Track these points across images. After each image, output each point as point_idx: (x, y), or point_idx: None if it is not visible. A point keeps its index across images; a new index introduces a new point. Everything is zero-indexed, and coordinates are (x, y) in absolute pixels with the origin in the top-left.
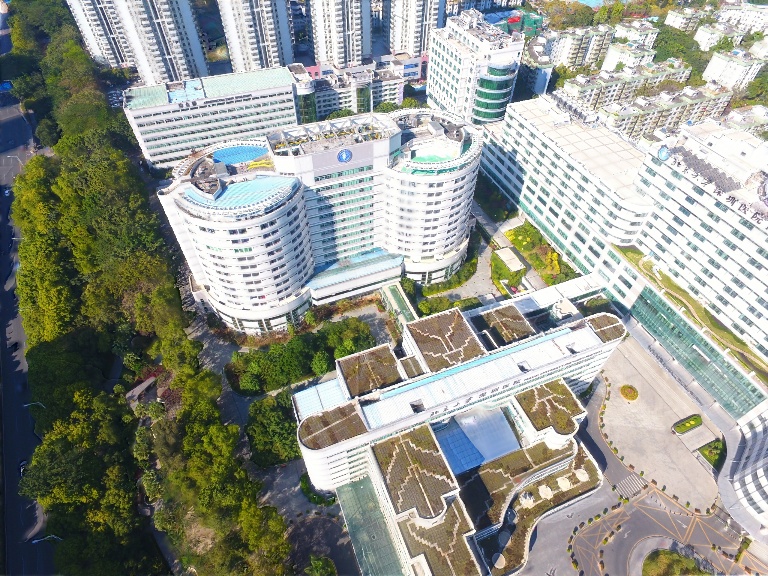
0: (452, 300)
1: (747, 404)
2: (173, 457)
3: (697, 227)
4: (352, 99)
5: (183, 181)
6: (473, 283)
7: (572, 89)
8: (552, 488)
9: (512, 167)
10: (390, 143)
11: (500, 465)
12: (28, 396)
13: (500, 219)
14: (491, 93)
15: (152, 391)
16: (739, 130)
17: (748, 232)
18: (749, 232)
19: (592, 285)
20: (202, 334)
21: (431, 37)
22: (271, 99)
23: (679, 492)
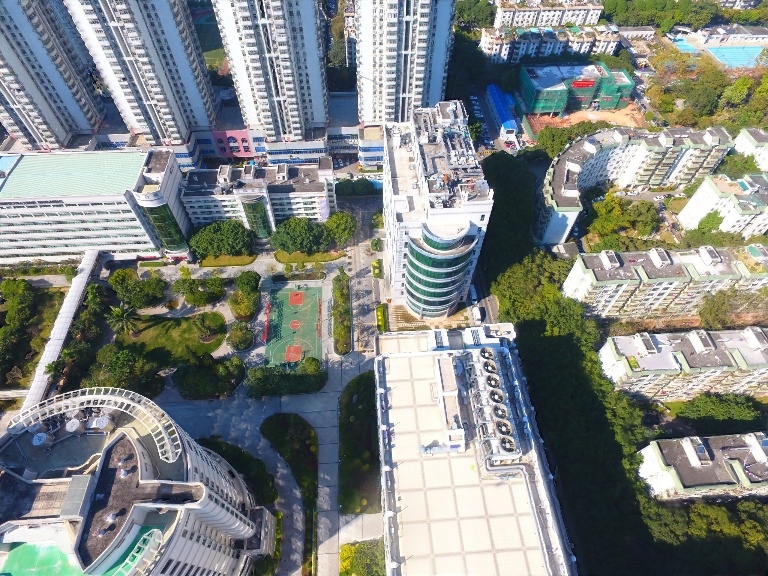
0: None
1: None
2: None
3: None
4: None
5: None
6: None
7: (584, 274)
8: None
9: None
10: None
11: None
12: None
13: (349, 512)
14: (423, 268)
15: None
16: None
17: None
18: None
19: None
20: None
21: None
22: (96, 208)
23: None
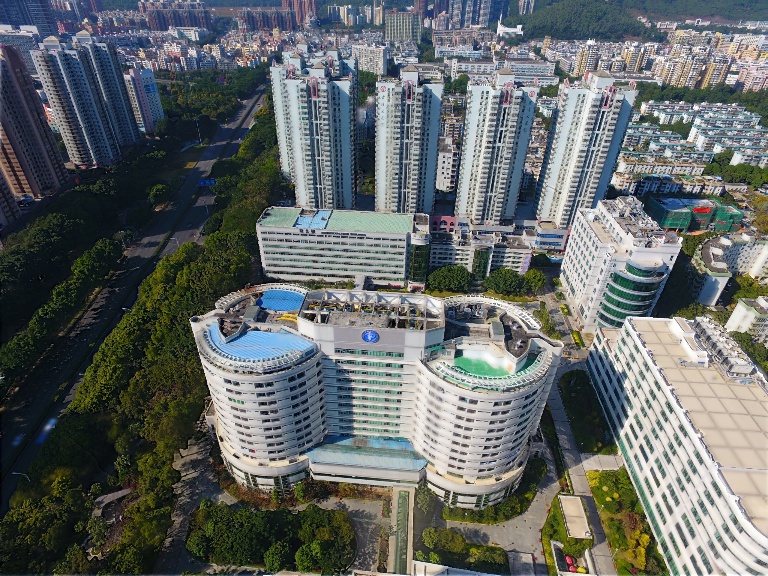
0: (476, 540)
1: None
2: None
3: None
4: (469, 258)
5: (216, 314)
6: (514, 527)
7: (747, 312)
8: None
9: (619, 391)
10: (426, 336)
11: None
12: None
13: (588, 450)
14: (625, 292)
15: None
16: None
17: None
18: None
19: None
20: (202, 459)
21: (576, 215)
22: (384, 242)
23: None
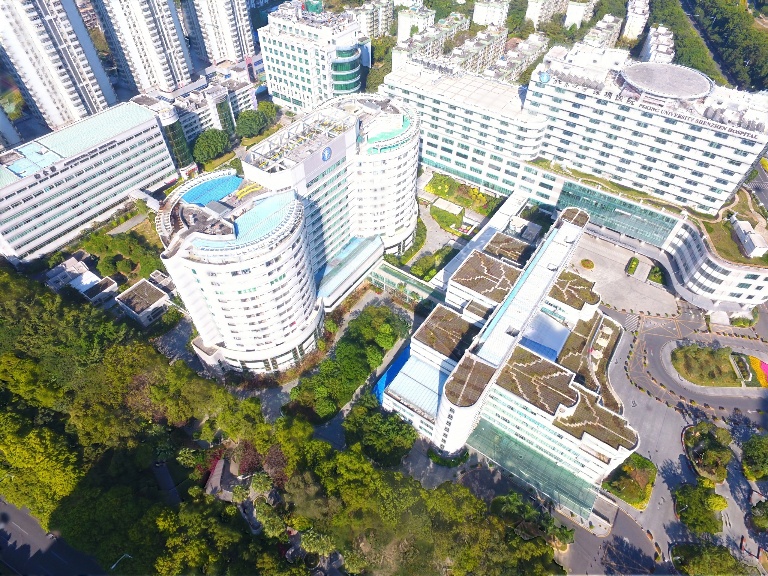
0: None
1: (666, 232)
2: (324, 504)
3: (587, 124)
4: (213, 117)
5: (183, 235)
6: (431, 238)
7: (401, 55)
8: (598, 349)
9: None
10: (355, 130)
11: (568, 350)
12: (76, 570)
13: None
14: (347, 74)
15: (225, 475)
16: (583, 46)
17: (627, 114)
18: (627, 113)
19: (521, 200)
20: None
21: (259, 37)
22: (138, 139)
23: (657, 310)
